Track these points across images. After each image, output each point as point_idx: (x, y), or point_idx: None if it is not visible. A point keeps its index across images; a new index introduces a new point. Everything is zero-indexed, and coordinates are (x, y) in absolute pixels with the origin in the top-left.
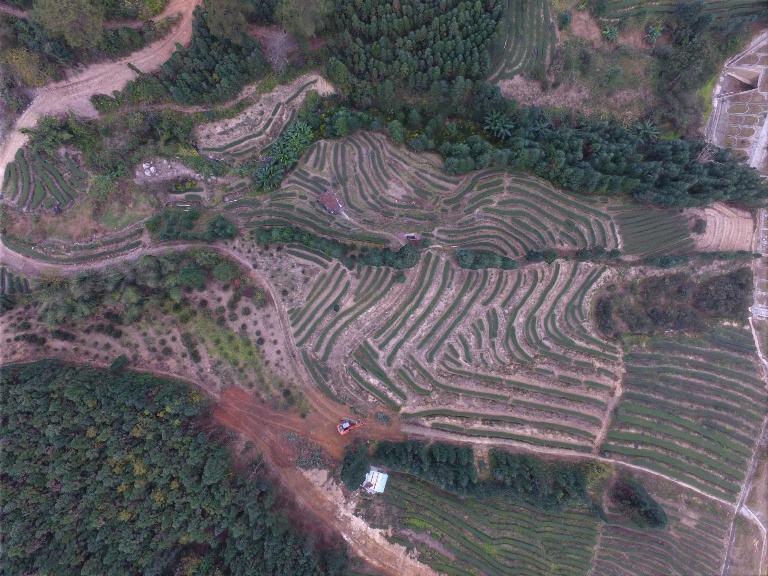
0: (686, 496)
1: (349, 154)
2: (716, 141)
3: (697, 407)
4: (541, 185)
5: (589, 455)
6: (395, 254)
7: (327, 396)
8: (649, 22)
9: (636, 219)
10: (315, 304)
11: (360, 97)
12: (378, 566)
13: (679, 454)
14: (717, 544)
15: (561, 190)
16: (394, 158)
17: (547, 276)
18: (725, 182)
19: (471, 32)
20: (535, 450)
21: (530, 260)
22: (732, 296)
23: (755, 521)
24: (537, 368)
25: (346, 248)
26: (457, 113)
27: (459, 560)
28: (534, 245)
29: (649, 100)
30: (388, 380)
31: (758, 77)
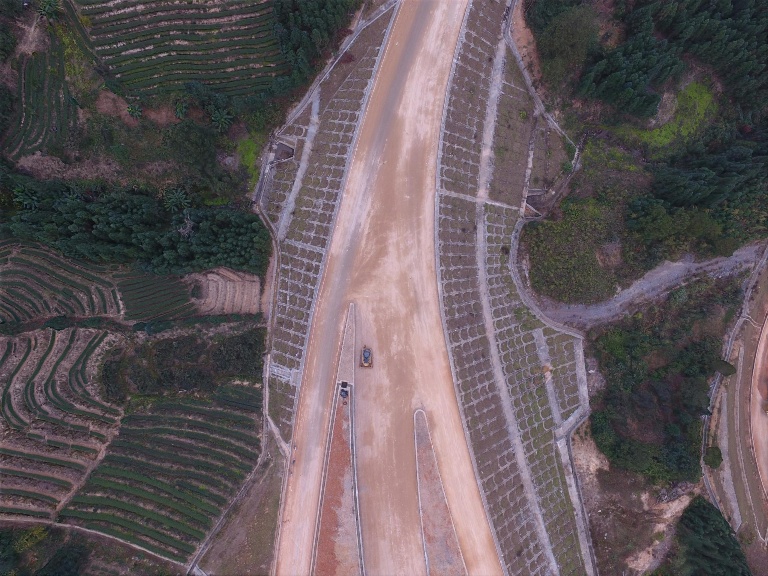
0: (137, 558)
1: None
2: (262, 206)
3: (177, 467)
4: (50, 255)
5: (46, 521)
6: None
7: None
8: (176, 99)
9: (135, 286)
10: None
11: None
12: None
13: (140, 516)
14: None
15: (71, 259)
16: None
17: (42, 343)
18: (213, 250)
19: None
20: None
21: None
22: (241, 356)
23: None
24: (29, 433)
25: None
26: None
27: None
28: (27, 314)
29: (185, 170)
30: None
31: None
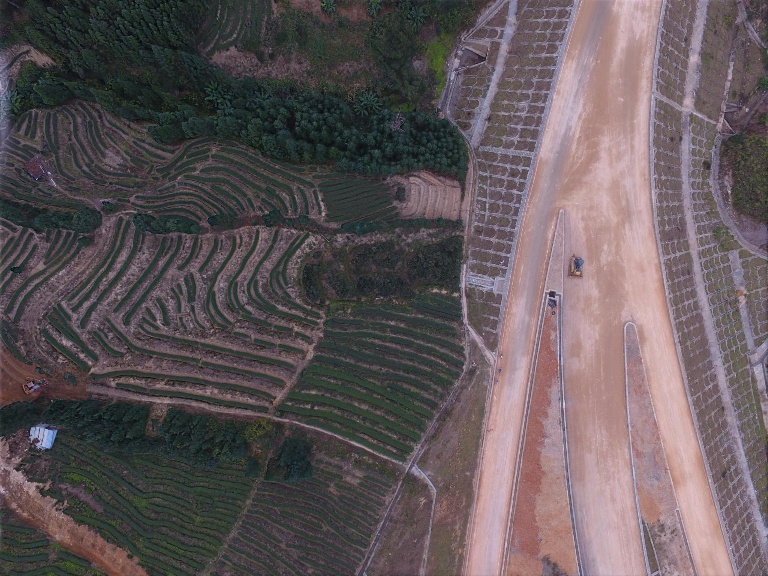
0: (357, 455)
1: (62, 123)
2: (449, 114)
3: (386, 370)
4: (249, 154)
5: (264, 415)
6: (68, 217)
7: (15, 356)
8: None
9: (338, 187)
10: (4, 267)
11: (75, 67)
12: (26, 517)
13: (356, 415)
14: (377, 501)
15: (270, 159)
16: (113, 128)
17: (246, 242)
18: (421, 150)
19: (160, 2)
20: (213, 410)
21: (210, 224)
22: (440, 264)
23: (425, 480)
24: (235, 332)
25: (33, 212)
26: (182, 84)
27: (106, 512)
28: (232, 211)
29: (375, 72)
30: (80, 342)
31: (487, 50)
